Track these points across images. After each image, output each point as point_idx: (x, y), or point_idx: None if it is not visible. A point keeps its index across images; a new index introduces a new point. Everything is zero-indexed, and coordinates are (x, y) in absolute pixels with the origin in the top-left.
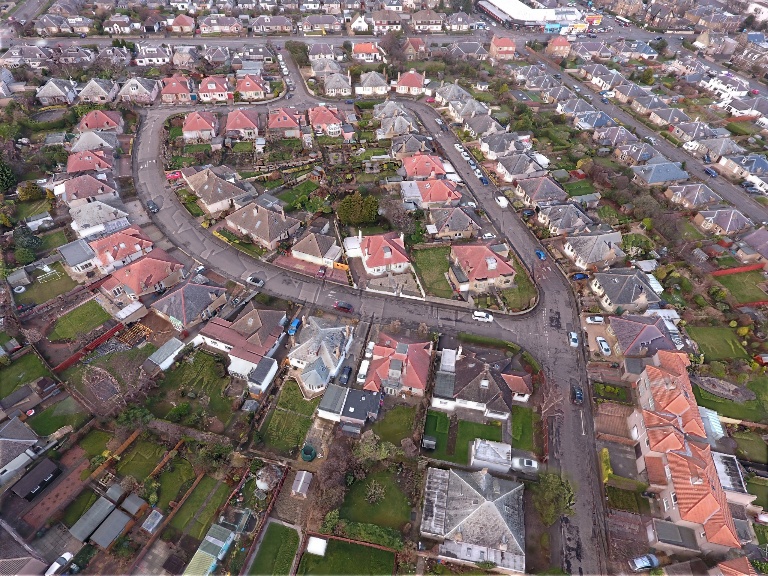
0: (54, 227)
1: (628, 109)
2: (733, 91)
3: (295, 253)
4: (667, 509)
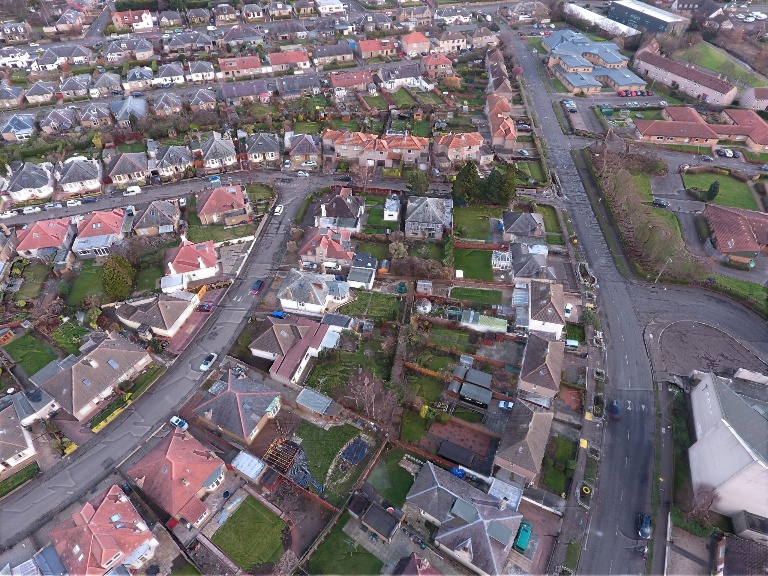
0: None
1: (2, 109)
2: (21, 57)
3: (171, 331)
4: (412, 159)
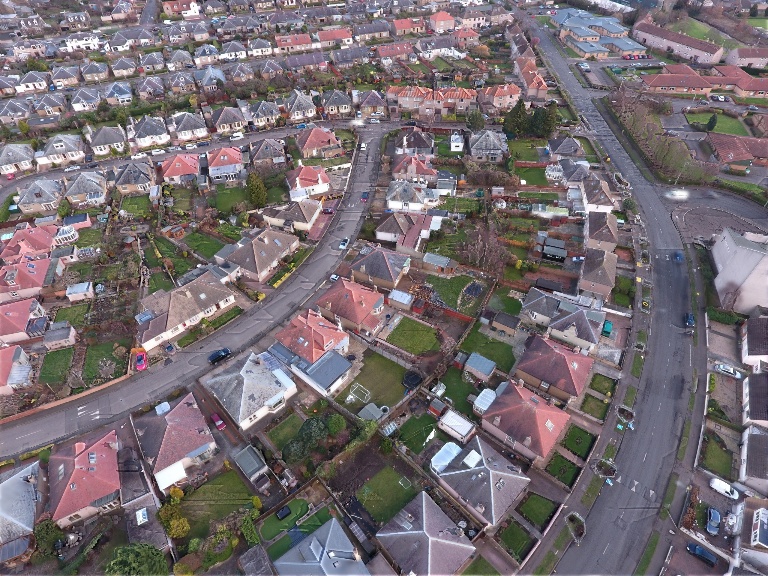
0: None
1: None
2: (93, 40)
3: (309, 225)
4: (463, 108)
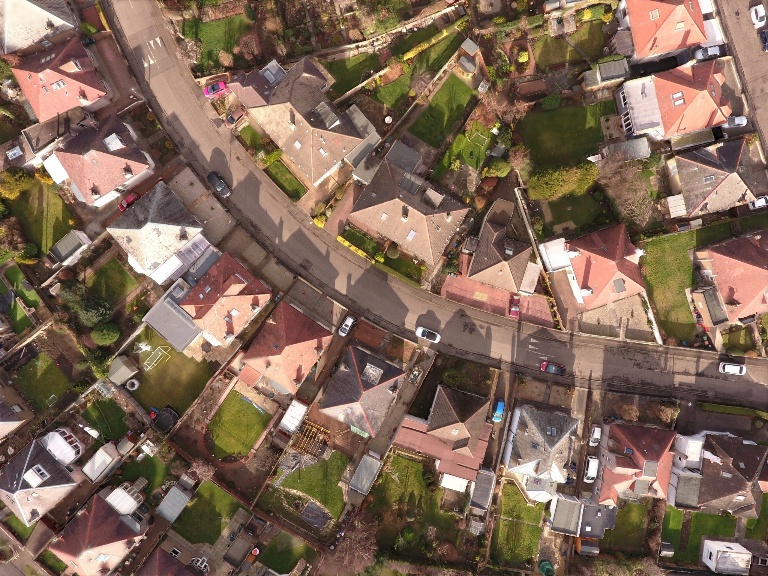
0: (98, 252)
1: None
2: None
3: None
4: None
